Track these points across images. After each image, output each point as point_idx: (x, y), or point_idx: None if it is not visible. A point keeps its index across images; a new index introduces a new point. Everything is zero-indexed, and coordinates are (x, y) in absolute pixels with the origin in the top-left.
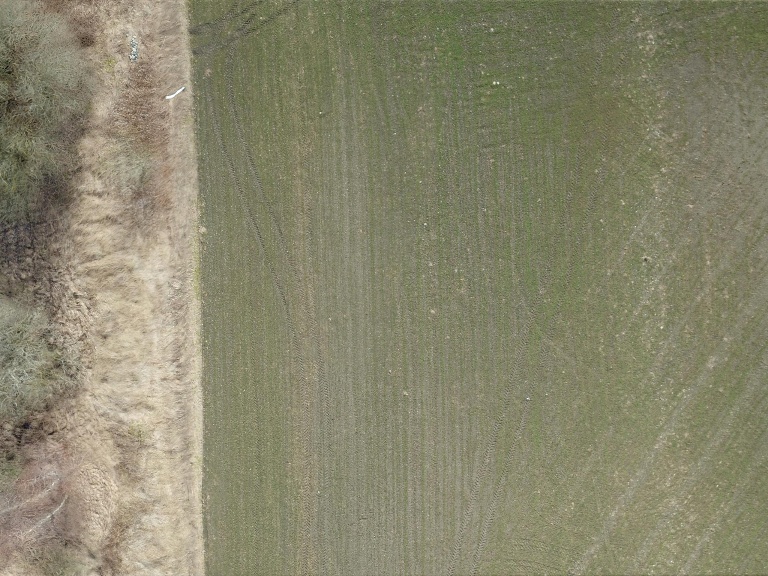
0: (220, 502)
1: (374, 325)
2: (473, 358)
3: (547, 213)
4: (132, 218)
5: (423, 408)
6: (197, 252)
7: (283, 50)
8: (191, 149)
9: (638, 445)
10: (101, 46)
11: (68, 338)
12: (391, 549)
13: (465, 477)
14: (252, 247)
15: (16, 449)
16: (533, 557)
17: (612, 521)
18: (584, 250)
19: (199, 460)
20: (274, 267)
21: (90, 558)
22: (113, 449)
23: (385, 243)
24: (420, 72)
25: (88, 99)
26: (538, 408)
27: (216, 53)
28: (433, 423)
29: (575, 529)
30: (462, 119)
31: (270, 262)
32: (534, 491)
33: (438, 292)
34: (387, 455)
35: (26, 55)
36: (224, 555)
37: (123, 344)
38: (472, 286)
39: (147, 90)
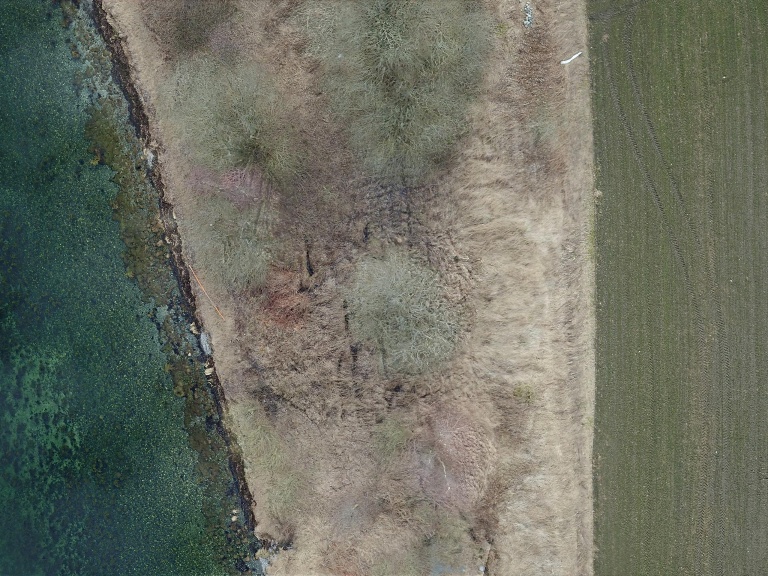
0: (612, 462)
1: None
2: None
3: None
4: (524, 182)
5: None
6: (592, 215)
7: (686, 15)
8: (587, 113)
9: None
10: (491, 12)
11: (445, 302)
12: None
13: None
14: (650, 210)
15: (386, 412)
16: None
17: None
18: None
19: (591, 421)
20: (673, 230)
21: (461, 520)
22: (493, 411)
23: None
24: None
25: (475, 65)
26: None
27: (614, 19)
28: None
29: None
30: None
31: (668, 225)
32: None
33: None
34: None
35: (409, 21)
36: (615, 515)
37: (510, 307)
38: None
39: (543, 55)
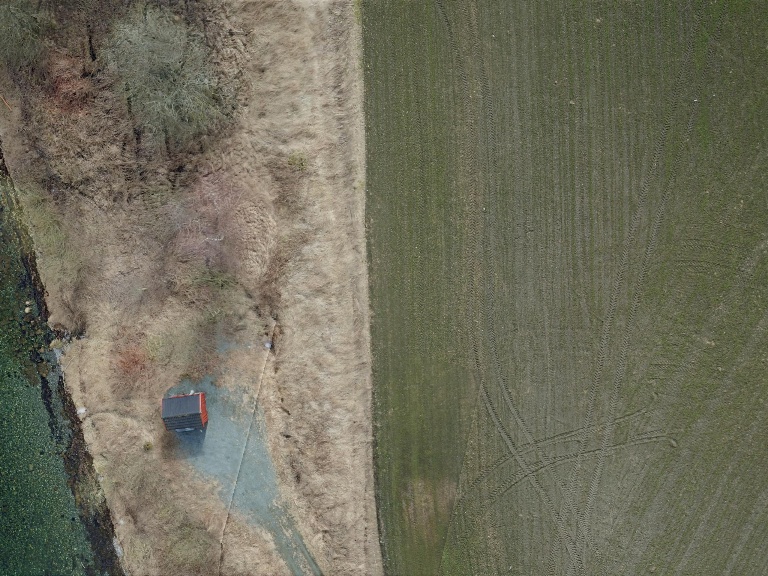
0: (384, 225)
1: (539, 38)
2: (639, 64)
3: None
4: None
5: (590, 117)
6: None
7: None
8: None
9: None
10: None
11: (223, 78)
12: (559, 259)
13: (633, 182)
14: None
15: (170, 193)
16: (703, 256)
17: None
18: None
19: (362, 184)
20: None
21: (247, 298)
22: (271, 184)
23: None
24: None
25: None
26: (706, 109)
27: None
28: (600, 131)
29: (744, 226)
30: None
31: None
32: (703, 191)
33: (603, 1)
34: (554, 166)
35: None
36: (389, 277)
37: (282, 75)
38: None
39: None
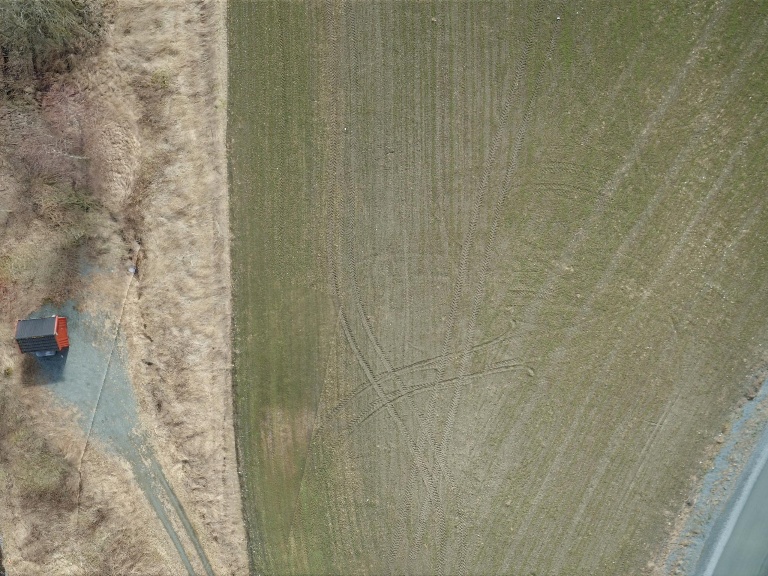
0: (245, 145)
1: None
2: None
3: None
4: None
5: (452, 34)
6: None
7: None
8: None
9: (670, 61)
10: None
11: None
12: (419, 181)
13: (494, 103)
14: None
15: (37, 113)
16: (563, 179)
17: (643, 139)
18: None
19: (224, 103)
20: None
21: (112, 221)
22: (136, 104)
23: None
24: None
25: None
26: (568, 27)
27: None
28: (462, 49)
29: (606, 148)
30: None
31: None
32: (564, 112)
33: None
34: (415, 85)
35: None
36: (249, 199)
37: None
38: None
39: None
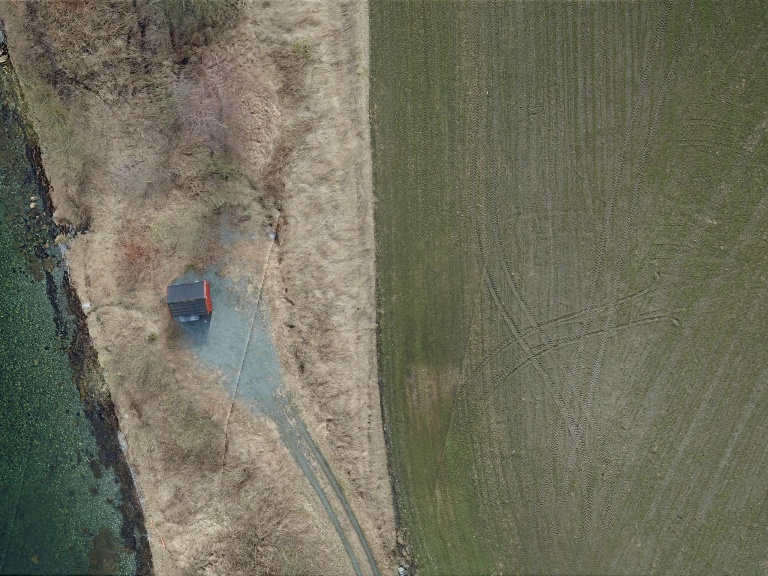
0: (388, 110)
1: None
2: None
3: None
4: None
5: None
6: None
7: None
8: None
9: None
10: None
11: None
12: (562, 141)
13: (635, 63)
14: None
15: (175, 86)
16: (705, 136)
17: None
18: None
19: (366, 70)
20: None
21: (251, 189)
22: (275, 74)
23: None
24: None
25: None
26: None
27: None
28: (603, 12)
29: (746, 105)
30: None
31: None
32: (705, 71)
33: None
34: (557, 48)
35: None
36: (392, 163)
37: None
38: None
39: None
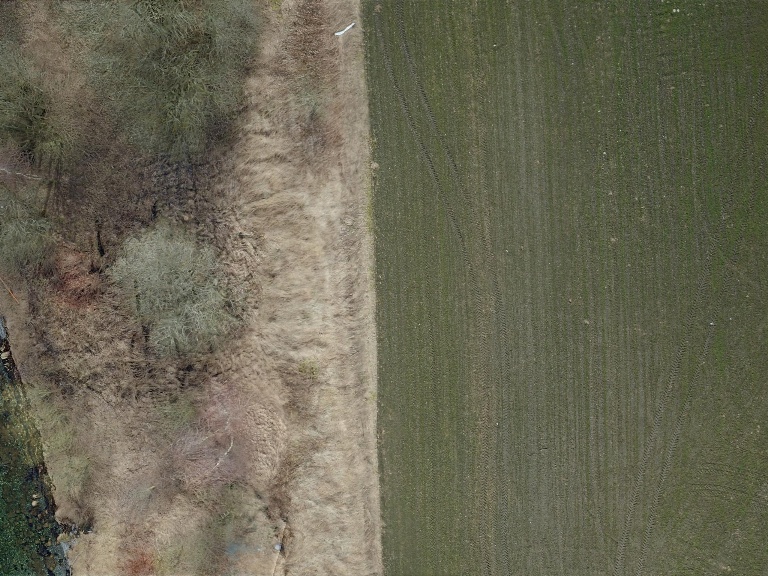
0: (396, 436)
1: (553, 255)
2: (655, 285)
3: (729, 139)
4: (302, 155)
5: (604, 336)
6: (369, 188)
7: None
8: (362, 85)
9: None
10: None
11: (233, 279)
12: (573, 477)
13: (648, 404)
14: (426, 181)
15: (179, 392)
16: (719, 481)
17: None
18: (767, 175)
19: (374, 395)
20: (449, 201)
21: (257, 499)
22: (281, 388)
23: (563, 173)
24: (598, 2)
25: (253, 38)
26: (722, 333)
27: None
28: (615, 351)
29: (761, 452)
30: (641, 47)
31: (444, 196)
32: (719, 415)
33: (618, 220)
34: (568, 384)
35: None
36: (400, 489)
37: (293, 282)
38: (653, 213)
39: (316, 27)
